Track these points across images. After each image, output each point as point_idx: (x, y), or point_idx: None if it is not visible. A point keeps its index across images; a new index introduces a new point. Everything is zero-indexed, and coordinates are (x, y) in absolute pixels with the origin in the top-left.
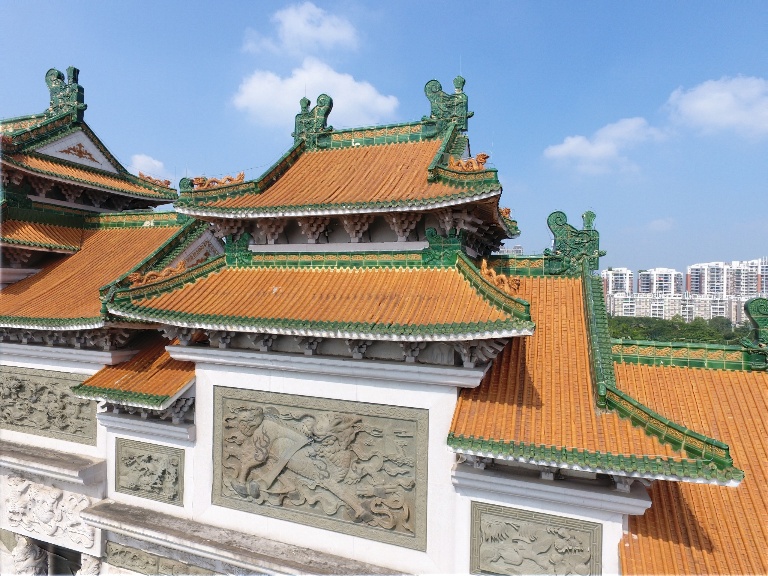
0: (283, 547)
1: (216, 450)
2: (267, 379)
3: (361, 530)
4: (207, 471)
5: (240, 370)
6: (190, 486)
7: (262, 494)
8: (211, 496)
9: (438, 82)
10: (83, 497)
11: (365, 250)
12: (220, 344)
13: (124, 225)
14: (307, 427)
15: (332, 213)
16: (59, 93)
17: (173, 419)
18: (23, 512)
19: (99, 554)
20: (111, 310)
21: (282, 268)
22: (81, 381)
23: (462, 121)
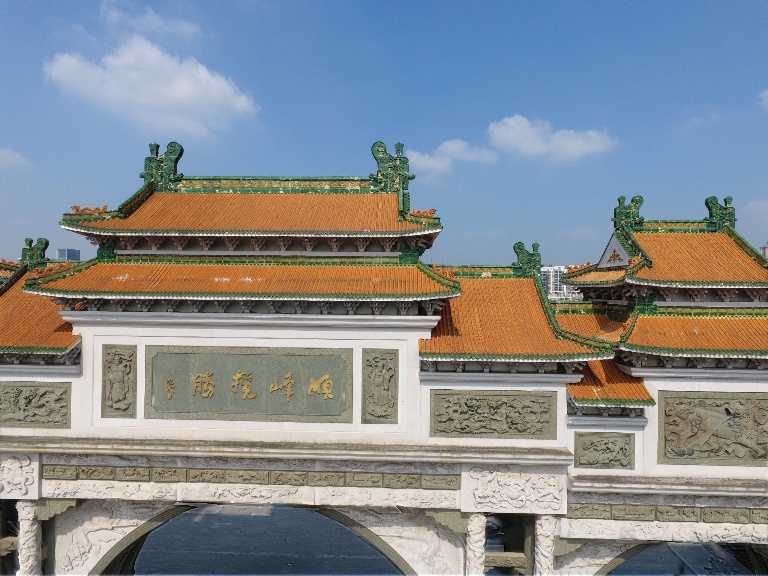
0: (716, 480)
1: (660, 430)
2: (698, 384)
3: (760, 463)
4: (654, 444)
5: (678, 380)
6: (640, 455)
7: (695, 452)
8: (657, 459)
9: (716, 198)
10: (552, 475)
11: (735, 306)
12: (667, 365)
13: (461, 275)
14: (732, 409)
15: (736, 287)
16: (388, 163)
17: (630, 414)
18: (493, 495)
19: (566, 512)
20: (623, 348)
21: (681, 316)
22: (540, 396)
23: (732, 224)
